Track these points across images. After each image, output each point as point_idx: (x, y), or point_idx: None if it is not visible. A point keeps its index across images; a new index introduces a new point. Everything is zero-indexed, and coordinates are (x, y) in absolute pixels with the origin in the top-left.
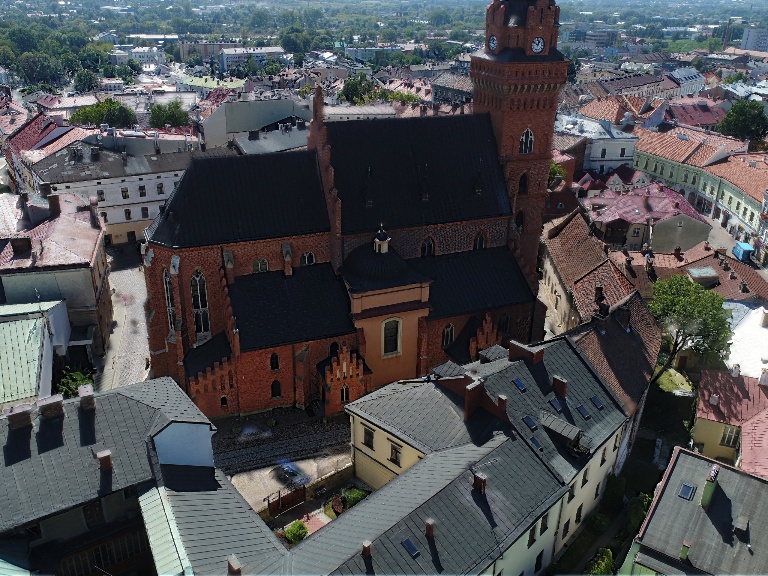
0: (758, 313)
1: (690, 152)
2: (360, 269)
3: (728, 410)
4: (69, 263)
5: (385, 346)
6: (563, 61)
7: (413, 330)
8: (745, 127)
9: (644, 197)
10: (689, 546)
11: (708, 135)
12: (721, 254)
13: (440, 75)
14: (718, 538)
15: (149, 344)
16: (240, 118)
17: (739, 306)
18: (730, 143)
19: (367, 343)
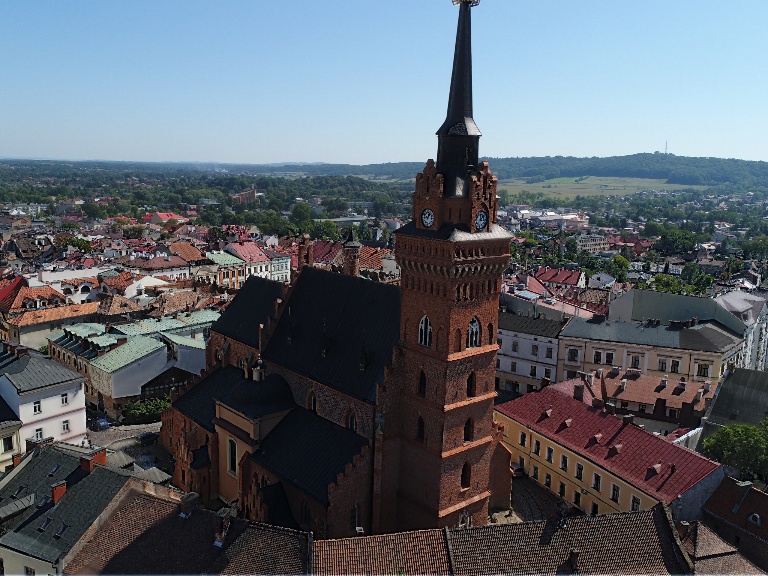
0: None
1: None
2: None
3: None
4: None
5: None
6: (446, 240)
7: None
8: None
9: None
10: None
11: None
12: None
13: None
14: None
15: None
16: (649, 307)
17: None
18: None
19: None
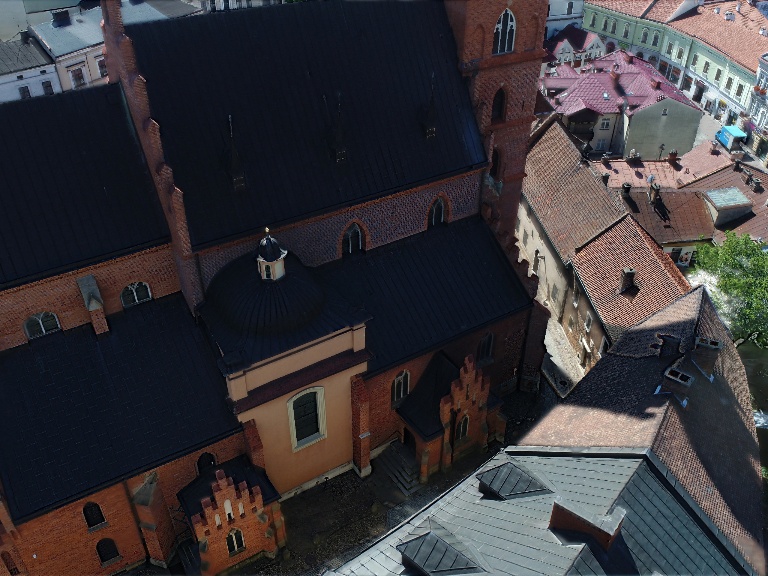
0: None
1: (650, 3)
2: (235, 316)
3: None
4: None
5: (297, 431)
6: None
7: (343, 397)
8: None
9: (614, 75)
10: None
11: None
12: (742, 164)
13: None
14: None
15: None
16: None
17: None
18: None
19: (265, 438)
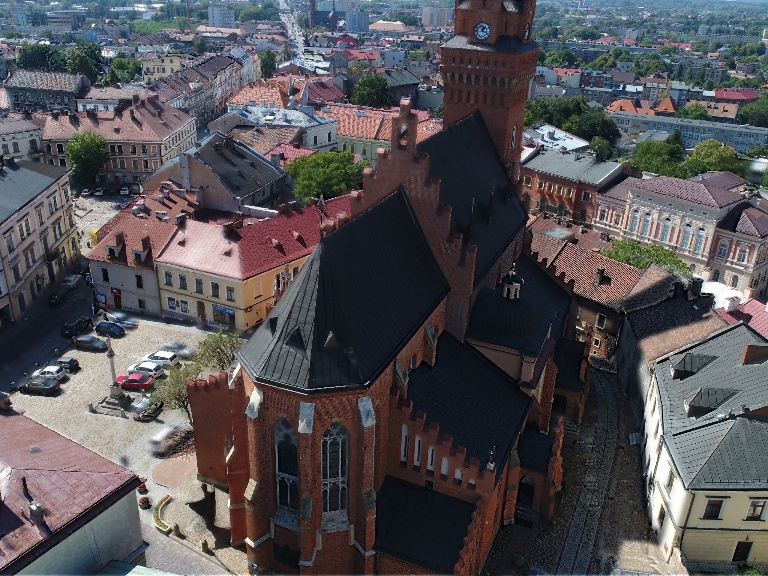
0: None
1: (377, 128)
2: (512, 325)
3: None
4: (106, 493)
5: None
6: None
7: None
8: (379, 99)
9: None
10: None
11: (362, 110)
12: None
13: (12, 74)
14: None
15: (255, 555)
16: None
17: None
18: (387, 115)
19: None
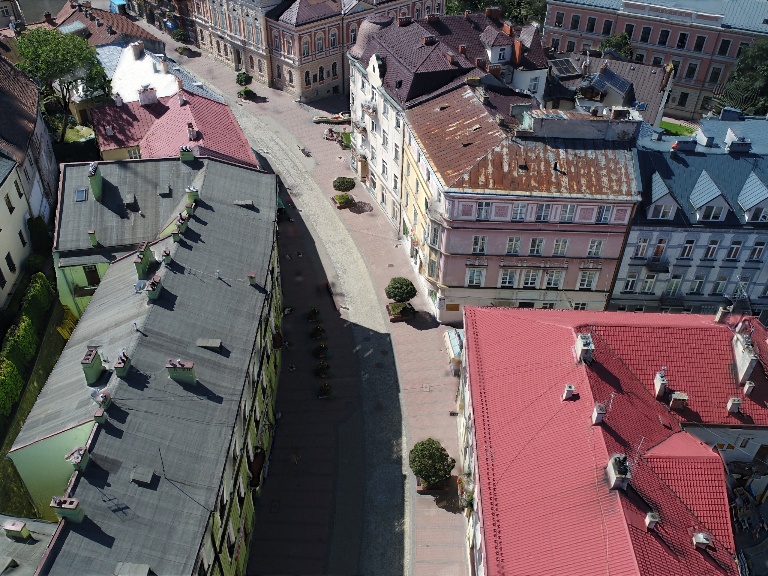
0: (130, 50)
1: None
2: None
3: (125, 136)
4: None
5: None
6: None
7: None
8: None
9: None
10: (93, 232)
11: None
12: (85, 7)
13: None
14: (116, 218)
15: None
16: None
17: (112, 48)
18: None
19: None
